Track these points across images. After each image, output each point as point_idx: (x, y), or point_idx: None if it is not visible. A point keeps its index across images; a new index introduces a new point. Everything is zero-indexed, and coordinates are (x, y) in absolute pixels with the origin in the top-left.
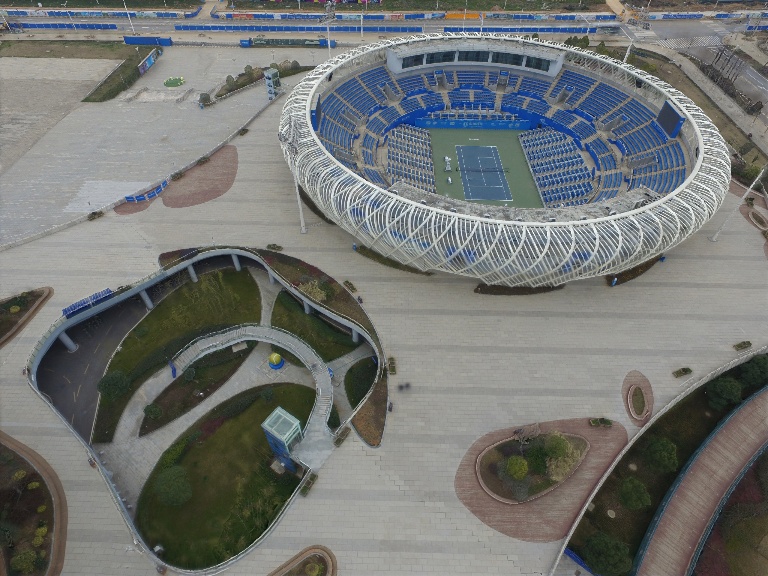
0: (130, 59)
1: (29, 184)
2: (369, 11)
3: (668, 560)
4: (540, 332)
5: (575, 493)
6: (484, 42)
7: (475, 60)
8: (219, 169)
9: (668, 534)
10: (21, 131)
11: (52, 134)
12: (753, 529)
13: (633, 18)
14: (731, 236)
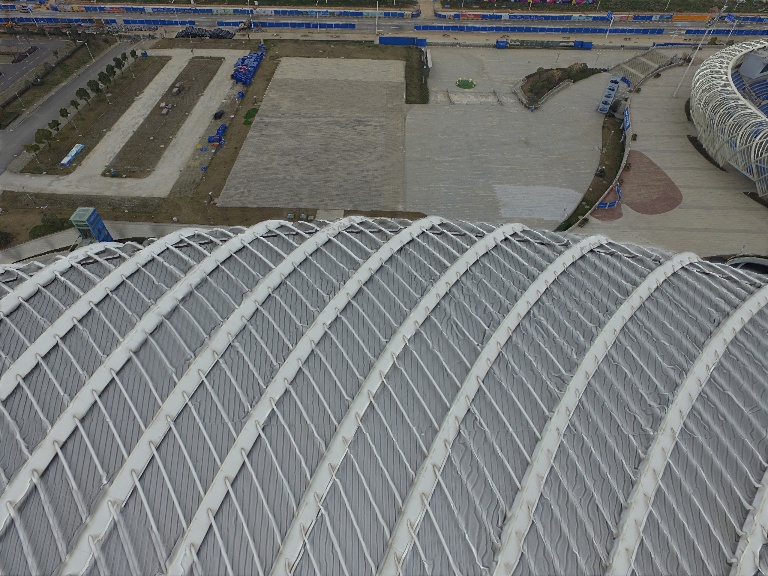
0: (408, 60)
1: (441, 188)
2: (588, 12)
3: None
4: None
5: None
6: None
7: None
8: (650, 175)
9: None
10: (379, 133)
11: (412, 137)
12: None
13: None
14: None
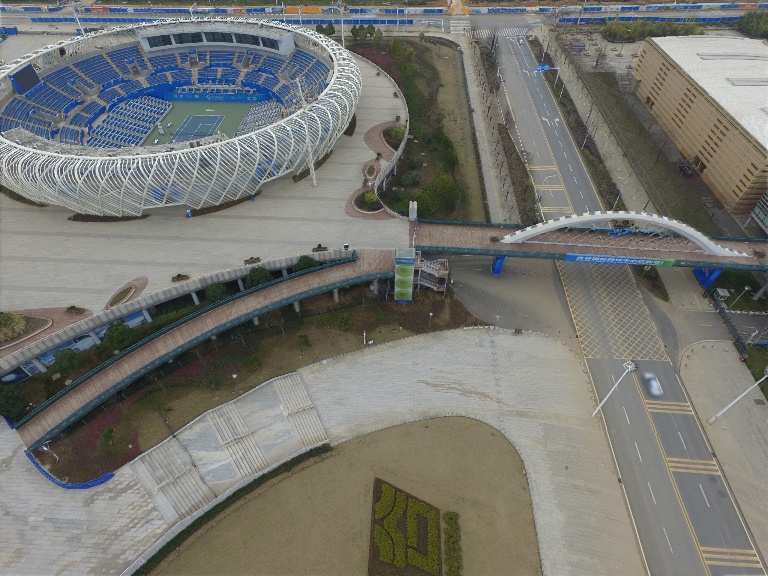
0: None
1: None
2: (221, 6)
3: (68, 409)
4: (93, 248)
5: (6, 355)
6: (228, 25)
7: (223, 41)
8: None
9: (84, 392)
10: None
11: None
12: (170, 395)
13: (461, 12)
14: (334, 183)
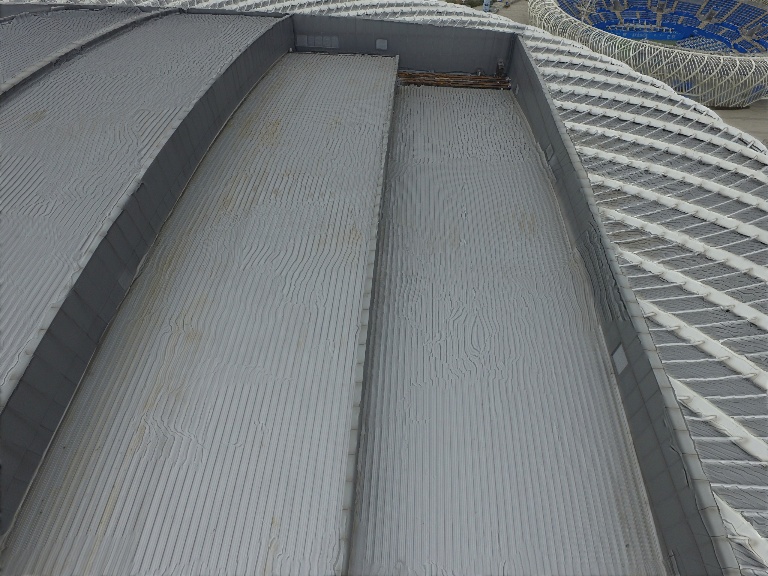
0: None
1: None
2: None
3: None
4: (742, 125)
5: None
6: None
7: None
8: None
9: None
10: None
11: None
12: None
13: None
14: None
